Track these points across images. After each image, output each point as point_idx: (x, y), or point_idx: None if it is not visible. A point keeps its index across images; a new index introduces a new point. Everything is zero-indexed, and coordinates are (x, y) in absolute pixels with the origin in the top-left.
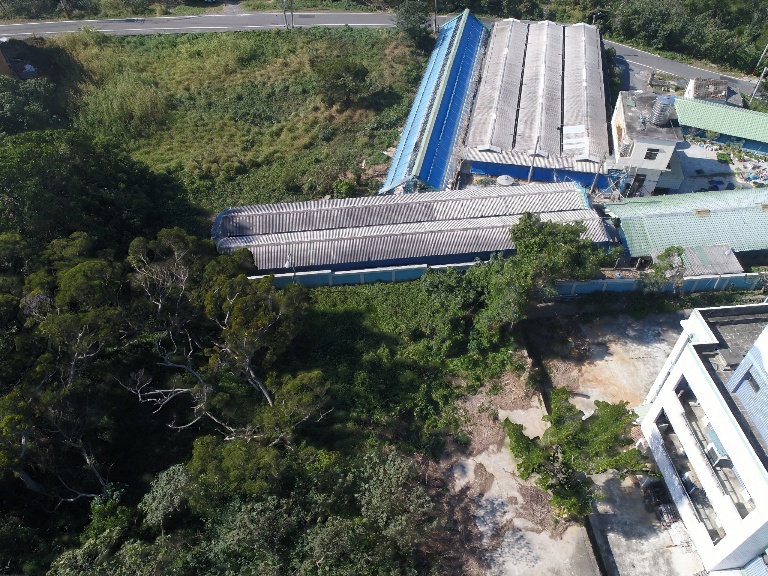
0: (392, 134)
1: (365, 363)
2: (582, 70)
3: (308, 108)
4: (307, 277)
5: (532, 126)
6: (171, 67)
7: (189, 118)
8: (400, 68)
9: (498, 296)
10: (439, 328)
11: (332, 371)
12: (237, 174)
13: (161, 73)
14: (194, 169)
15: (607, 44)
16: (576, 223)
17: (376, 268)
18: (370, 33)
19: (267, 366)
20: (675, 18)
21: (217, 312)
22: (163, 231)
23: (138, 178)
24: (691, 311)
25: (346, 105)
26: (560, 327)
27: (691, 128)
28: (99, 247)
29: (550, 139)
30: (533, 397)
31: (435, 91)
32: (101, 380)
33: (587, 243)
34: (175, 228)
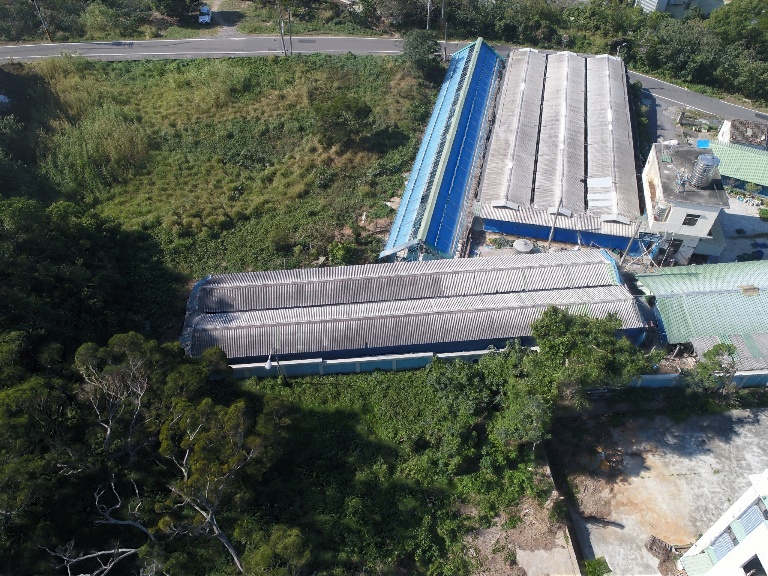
0: (396, 181)
1: (358, 484)
2: (607, 110)
3: (304, 149)
4: (294, 366)
5: (553, 178)
6: (157, 98)
7: (173, 160)
8: (406, 103)
9: (516, 401)
10: (446, 440)
11: (319, 495)
12: (222, 229)
13: (146, 105)
14: (173, 225)
15: (631, 75)
16: (609, 315)
17: (374, 356)
18: (375, 61)
19: (237, 507)
20: (706, 49)
21: (174, 449)
22: (115, 338)
23: (106, 241)
24: (740, 412)
25: (346, 145)
26: (587, 431)
27: (729, 179)
28: (49, 338)
29: (573, 194)
30: (558, 532)
31: (445, 134)
32: (28, 537)
33: (624, 346)
34: (130, 333)
